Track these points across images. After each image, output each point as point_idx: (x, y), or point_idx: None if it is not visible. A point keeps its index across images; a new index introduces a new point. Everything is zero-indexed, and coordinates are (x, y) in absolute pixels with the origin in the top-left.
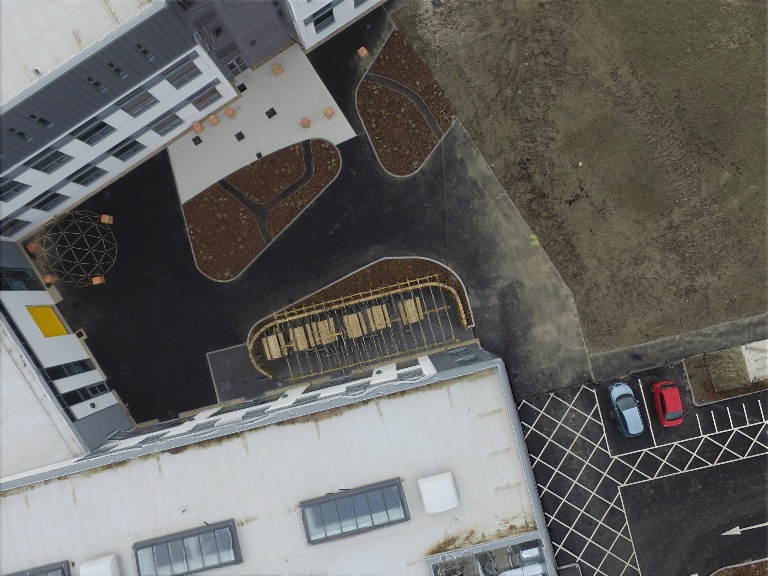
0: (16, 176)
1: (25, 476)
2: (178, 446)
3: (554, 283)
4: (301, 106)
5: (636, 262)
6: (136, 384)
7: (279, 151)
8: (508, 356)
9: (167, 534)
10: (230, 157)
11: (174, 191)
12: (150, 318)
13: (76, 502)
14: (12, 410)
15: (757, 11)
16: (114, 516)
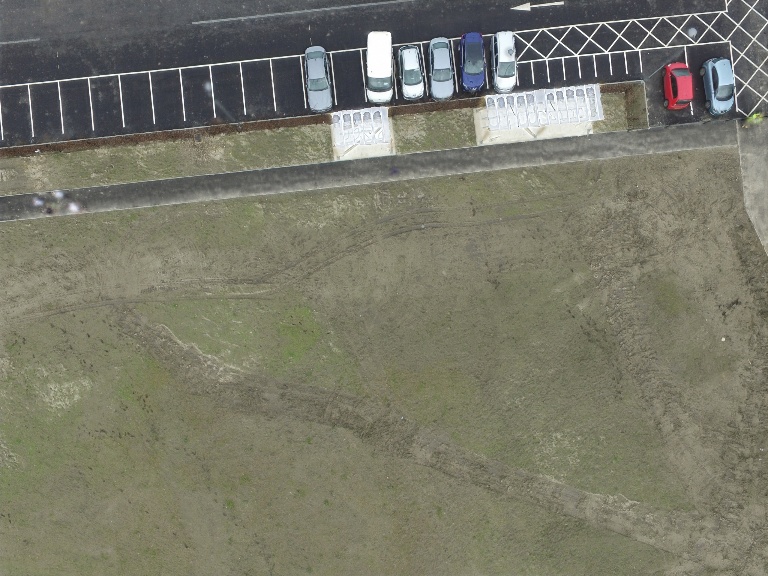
0: None
1: None
2: None
3: (763, 224)
4: None
5: (680, 233)
6: None
7: None
8: None
9: None
10: None
11: None
12: None
13: None
14: None
15: (530, 466)
16: None
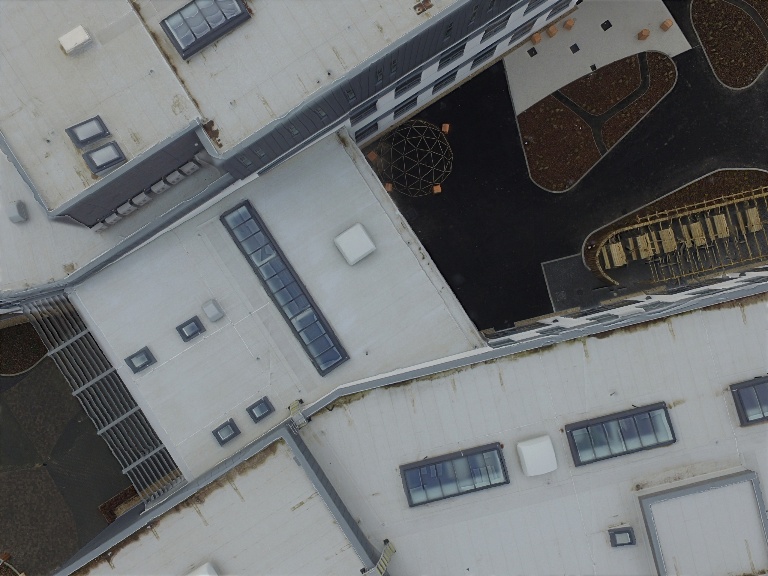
0: (427, 67)
1: (457, 359)
2: (604, 331)
3: None
4: (637, 19)
5: None
6: (472, 293)
7: (614, 63)
8: None
9: (597, 416)
10: (565, 69)
11: (509, 102)
12: (485, 228)
13: (503, 386)
14: (414, 301)
15: None
16: (541, 399)
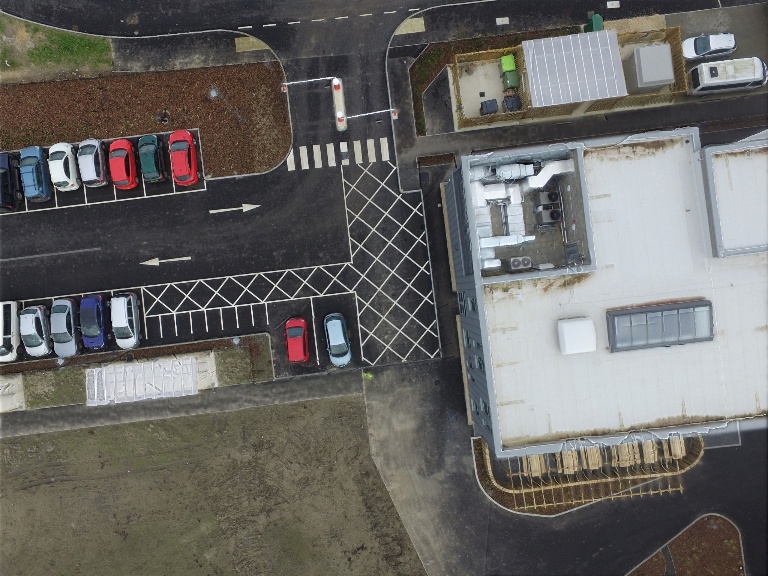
0: None
1: None
2: None
3: (388, 470)
4: None
5: (306, 481)
6: None
7: None
8: (442, 403)
9: None
10: None
11: None
12: None
13: None
14: None
15: None
16: None
